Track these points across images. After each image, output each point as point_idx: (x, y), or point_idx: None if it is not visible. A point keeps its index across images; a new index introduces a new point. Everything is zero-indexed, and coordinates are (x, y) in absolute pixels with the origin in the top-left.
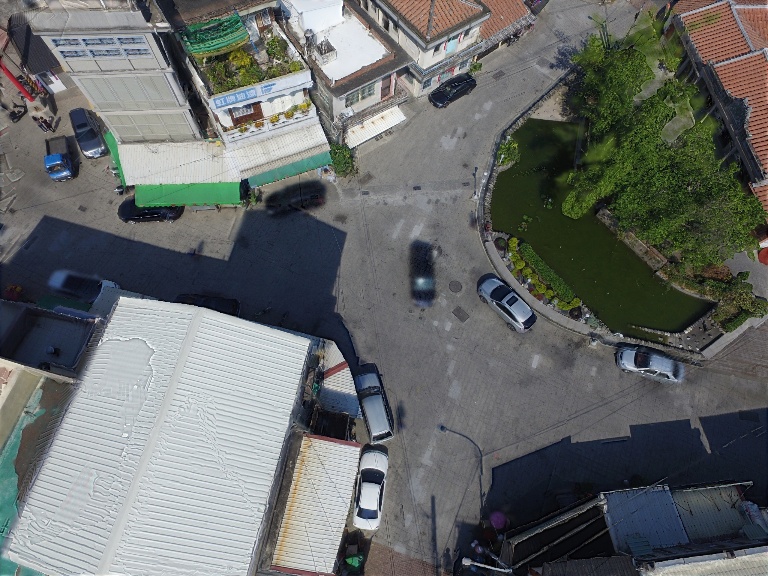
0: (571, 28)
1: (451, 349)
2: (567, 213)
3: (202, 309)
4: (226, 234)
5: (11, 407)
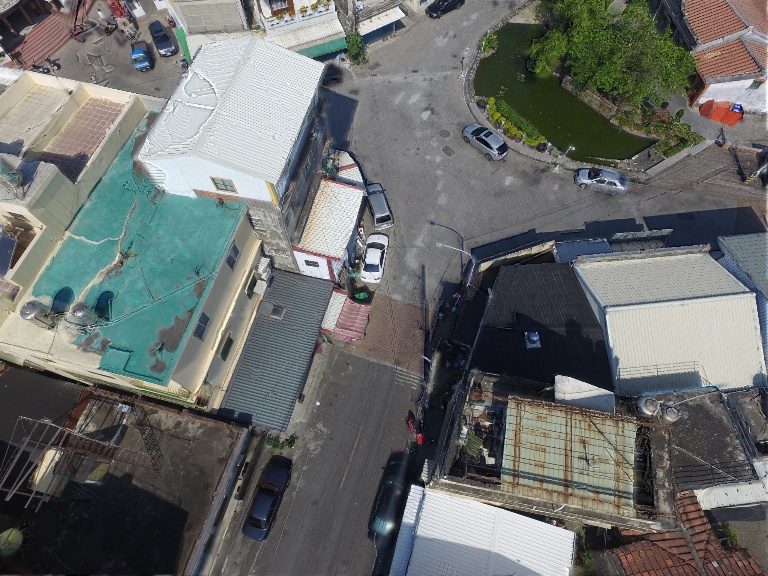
0: None
1: (440, 173)
2: (531, 69)
3: (256, 37)
4: None
5: (130, 119)
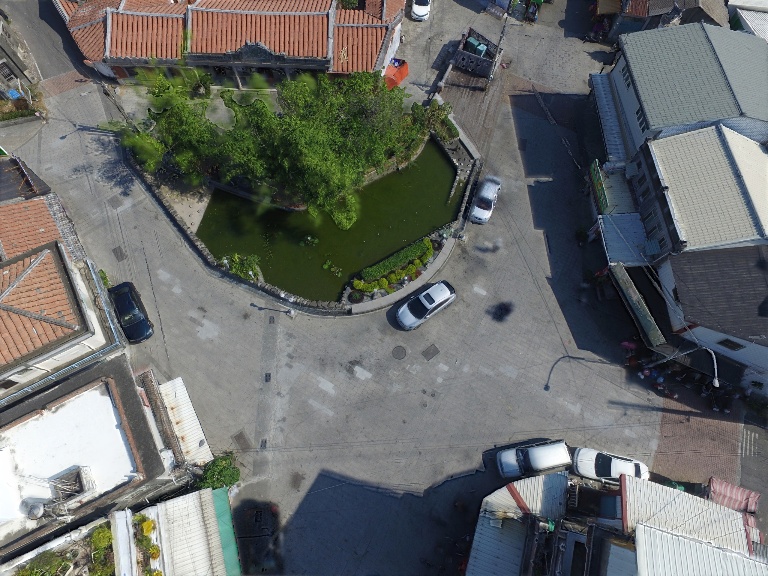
0: (72, 161)
1: (468, 368)
2: (348, 226)
3: None
4: None
5: None
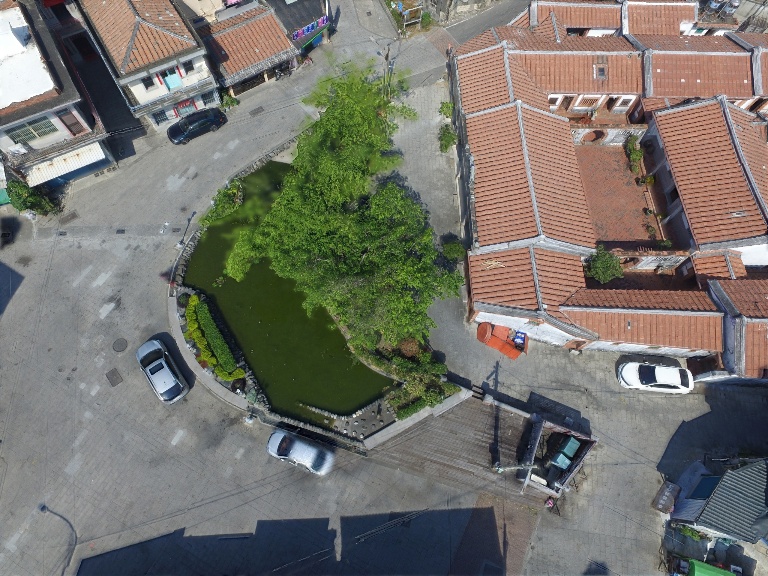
0: (354, 64)
1: (88, 417)
2: (231, 275)
3: None
4: None
5: None
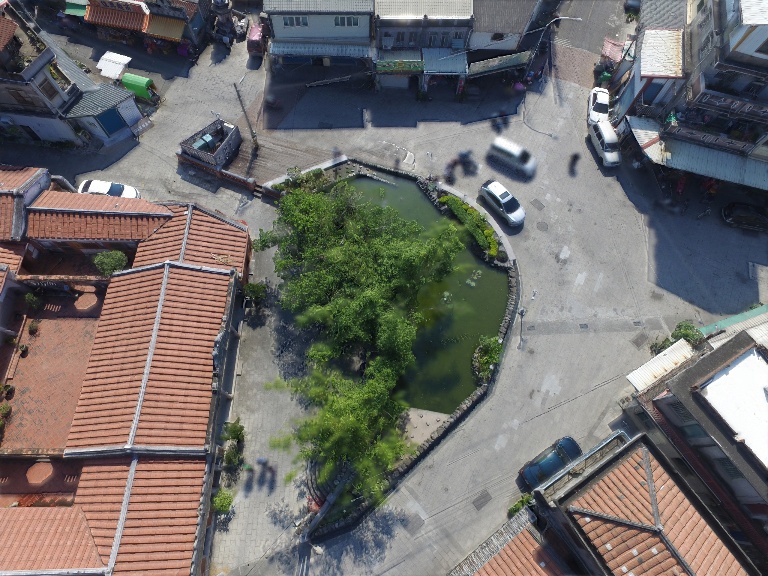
0: None
1: (546, 181)
2: None
3: None
4: (762, 287)
5: None
